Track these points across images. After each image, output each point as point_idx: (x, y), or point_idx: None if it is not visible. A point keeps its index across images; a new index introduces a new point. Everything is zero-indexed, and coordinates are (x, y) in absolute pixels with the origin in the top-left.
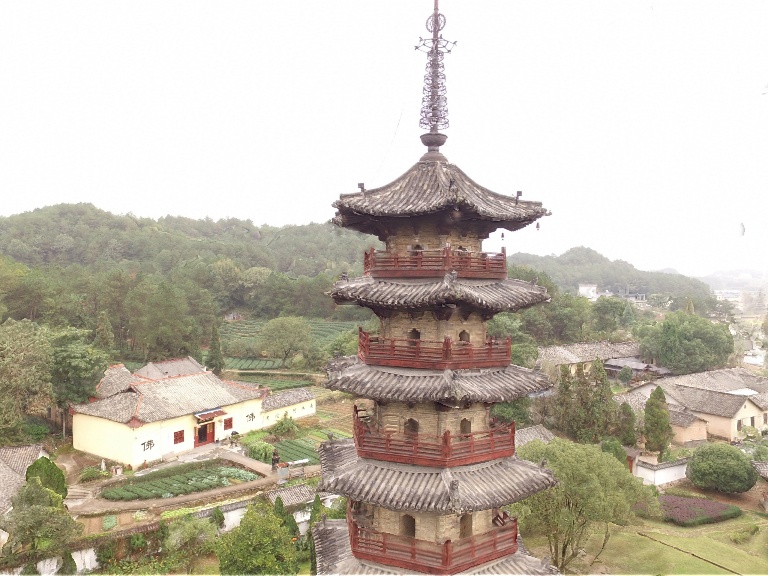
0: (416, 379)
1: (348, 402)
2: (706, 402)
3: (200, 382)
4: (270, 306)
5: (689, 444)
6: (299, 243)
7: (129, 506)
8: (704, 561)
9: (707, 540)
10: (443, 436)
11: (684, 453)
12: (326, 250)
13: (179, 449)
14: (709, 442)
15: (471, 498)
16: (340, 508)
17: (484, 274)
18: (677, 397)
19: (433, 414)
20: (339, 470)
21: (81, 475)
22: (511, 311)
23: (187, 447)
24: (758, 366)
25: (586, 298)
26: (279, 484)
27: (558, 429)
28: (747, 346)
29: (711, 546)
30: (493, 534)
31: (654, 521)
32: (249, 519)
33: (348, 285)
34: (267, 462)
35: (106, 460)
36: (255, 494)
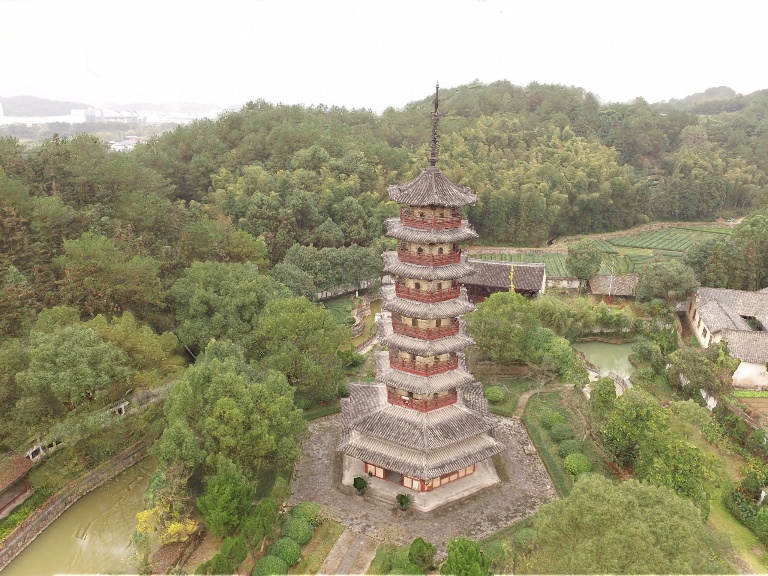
0: None
1: None
2: None
3: None
4: None
5: None
6: None
7: None
8: None
9: None
10: None
11: None
12: None
13: None
14: None
15: None
16: None
17: None
18: None
19: None
20: None
21: None
22: None
23: None
24: None
25: None
26: None
27: None
28: None
29: None
30: None
31: None
32: None
33: None
34: None
35: None
36: None
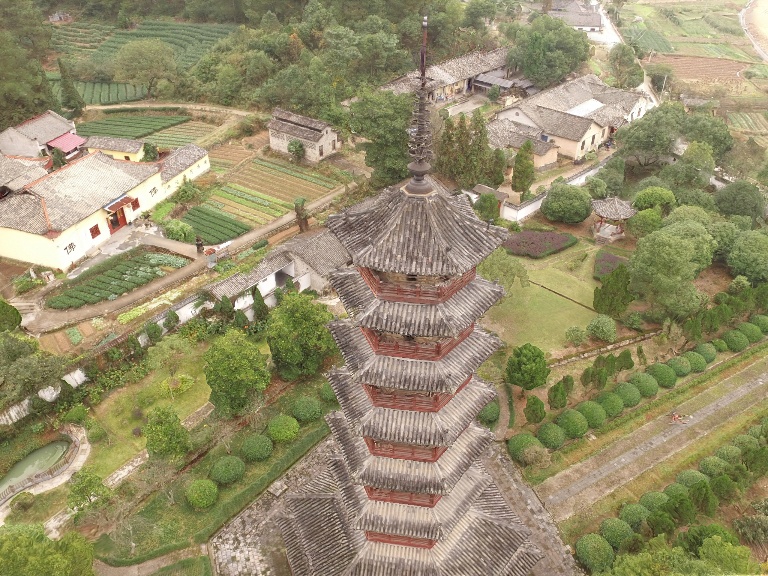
0: (415, 365)
1: (235, 143)
2: (560, 125)
3: (93, 167)
4: (104, 4)
5: (543, 168)
6: None
7: (83, 316)
8: (549, 291)
9: (552, 270)
10: (434, 397)
11: (541, 190)
12: None
13: (98, 241)
14: (558, 163)
15: (453, 430)
16: (288, 313)
17: (462, 286)
18: (537, 121)
19: None
20: (364, 421)
21: (16, 288)
22: None
23: (104, 237)
24: (602, 43)
25: (461, 3)
26: (210, 268)
27: (440, 173)
28: (596, 21)
29: (554, 276)
30: None
31: (515, 256)
32: (227, 350)
33: (365, 315)
34: (187, 240)
35: (29, 264)
36: (191, 281)
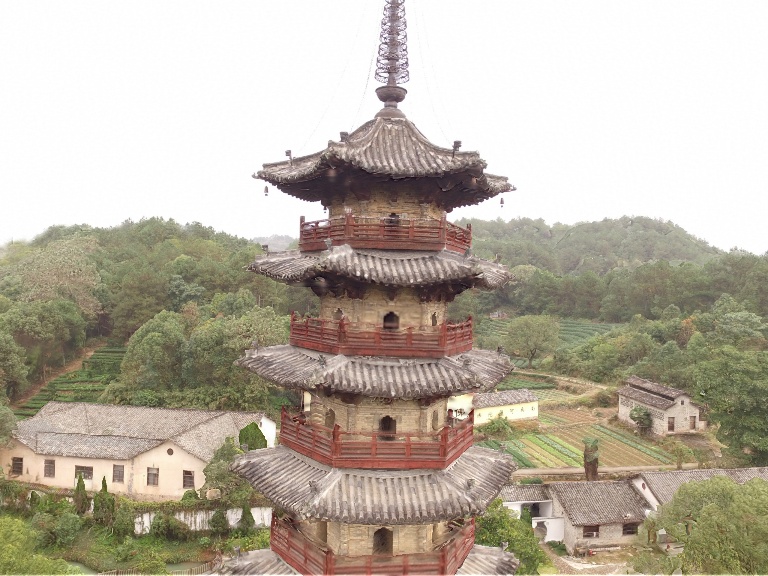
0: None
1: (584, 410)
2: None
3: None
4: (533, 305)
5: None
6: (589, 241)
7: None
8: None
9: None
10: (333, 430)
11: None
12: (619, 247)
13: None
14: None
15: (340, 506)
16: None
17: (405, 245)
18: None
19: (344, 406)
20: (253, 453)
21: None
22: (447, 290)
23: None
24: None
25: None
26: None
27: None
28: None
29: None
30: (403, 559)
31: None
32: None
33: (267, 259)
34: None
35: None
36: None
